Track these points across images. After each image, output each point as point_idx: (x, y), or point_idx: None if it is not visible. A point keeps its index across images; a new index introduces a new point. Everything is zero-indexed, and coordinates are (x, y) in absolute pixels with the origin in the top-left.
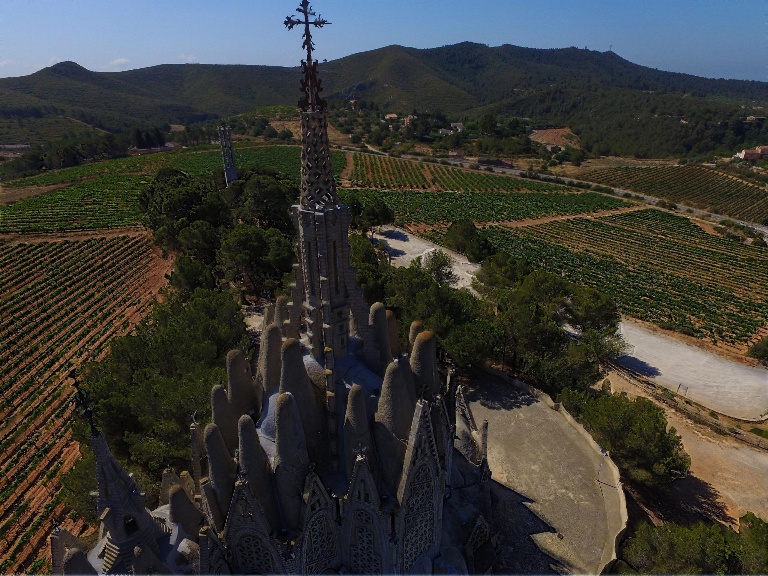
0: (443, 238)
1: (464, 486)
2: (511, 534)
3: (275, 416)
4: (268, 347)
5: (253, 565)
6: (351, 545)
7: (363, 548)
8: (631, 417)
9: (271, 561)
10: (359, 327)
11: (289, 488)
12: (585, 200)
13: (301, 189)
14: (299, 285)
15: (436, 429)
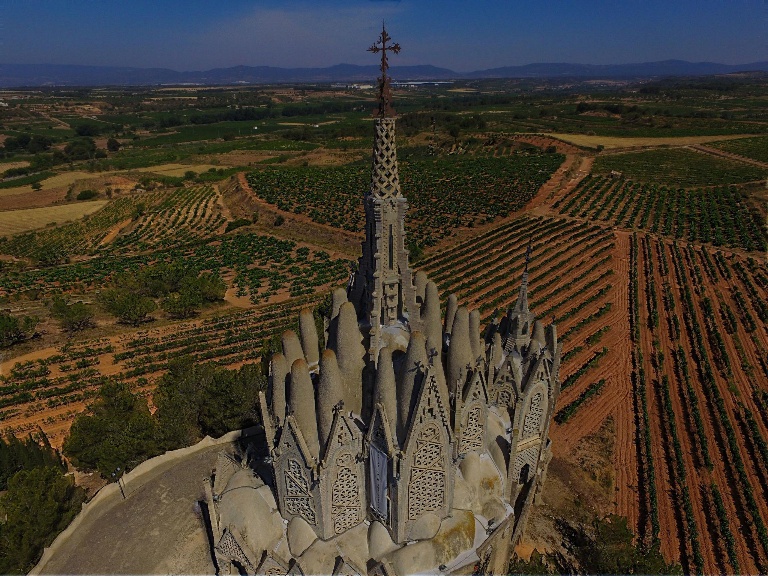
0: None
1: None
2: None
3: None
4: None
5: None
6: None
7: None
8: None
9: None
10: None
11: None
12: None
13: None
14: None
15: None
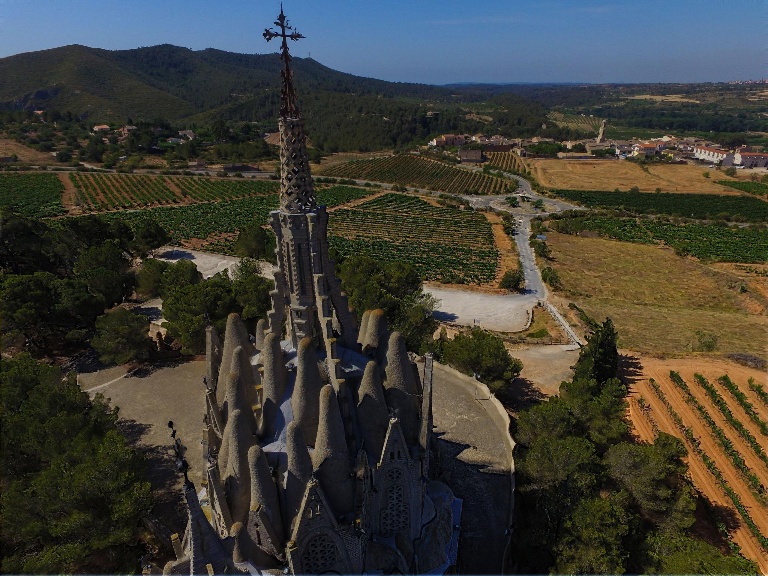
0: (233, 248)
1: None
2: (443, 463)
3: (324, 410)
4: (273, 357)
5: (317, 567)
6: (381, 509)
7: (393, 506)
8: (478, 346)
9: (336, 552)
10: (340, 316)
11: (340, 475)
12: (337, 193)
13: (285, 194)
14: (281, 290)
15: (417, 383)
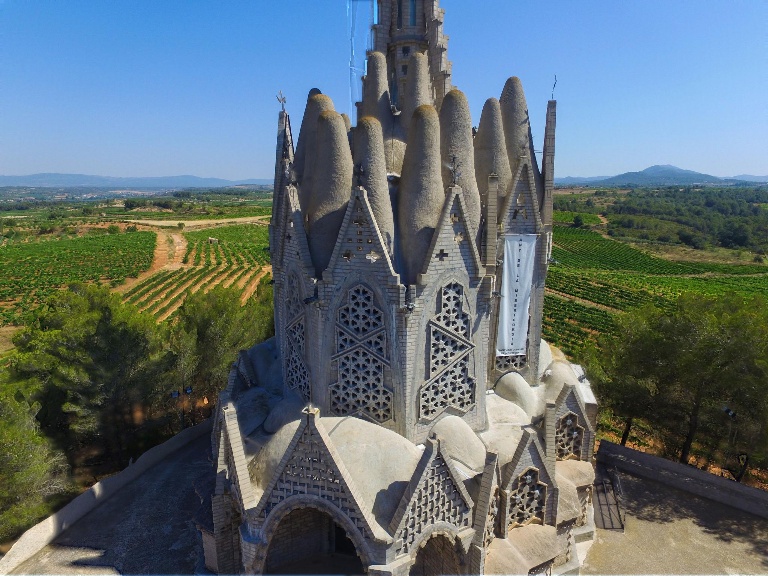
0: None
1: (264, 423)
2: (171, 568)
3: None
4: None
5: None
6: None
7: None
8: None
9: None
10: None
11: None
12: None
13: None
14: None
15: None
